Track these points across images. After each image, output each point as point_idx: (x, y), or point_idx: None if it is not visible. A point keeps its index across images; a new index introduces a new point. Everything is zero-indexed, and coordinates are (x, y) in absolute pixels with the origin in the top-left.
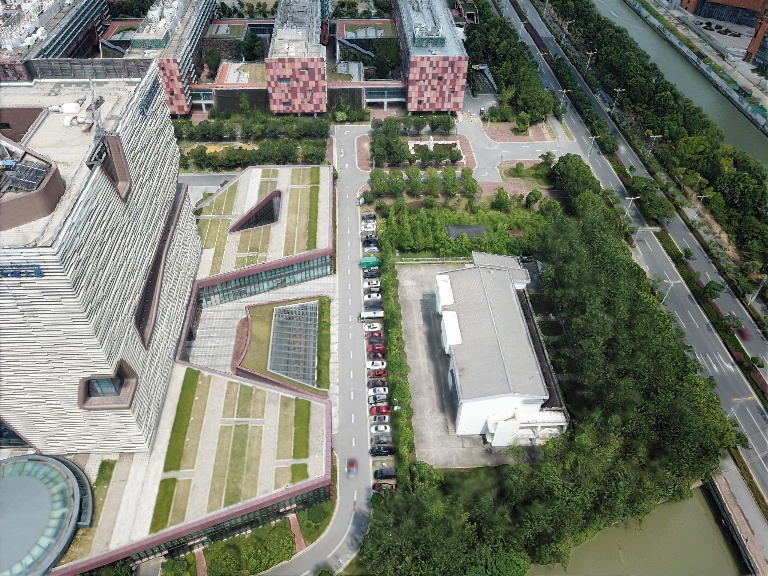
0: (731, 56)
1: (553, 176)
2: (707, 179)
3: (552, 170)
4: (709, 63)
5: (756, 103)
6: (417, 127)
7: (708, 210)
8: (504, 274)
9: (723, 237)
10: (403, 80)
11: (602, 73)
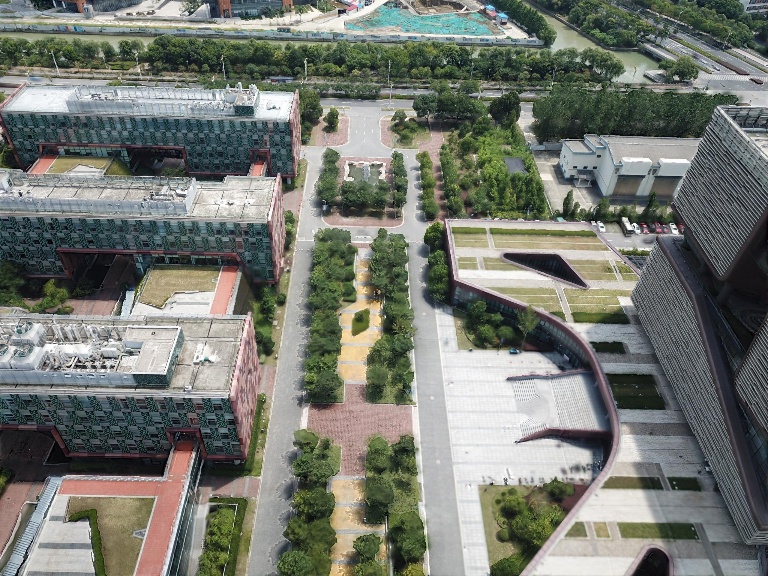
0: (219, 18)
1: (419, 122)
2: (428, 66)
3: (411, 120)
4: (223, 30)
5: (300, 31)
6: (337, 173)
7: (461, 76)
8: (605, 138)
9: (484, 81)
10: (220, 172)
11: (241, 68)
